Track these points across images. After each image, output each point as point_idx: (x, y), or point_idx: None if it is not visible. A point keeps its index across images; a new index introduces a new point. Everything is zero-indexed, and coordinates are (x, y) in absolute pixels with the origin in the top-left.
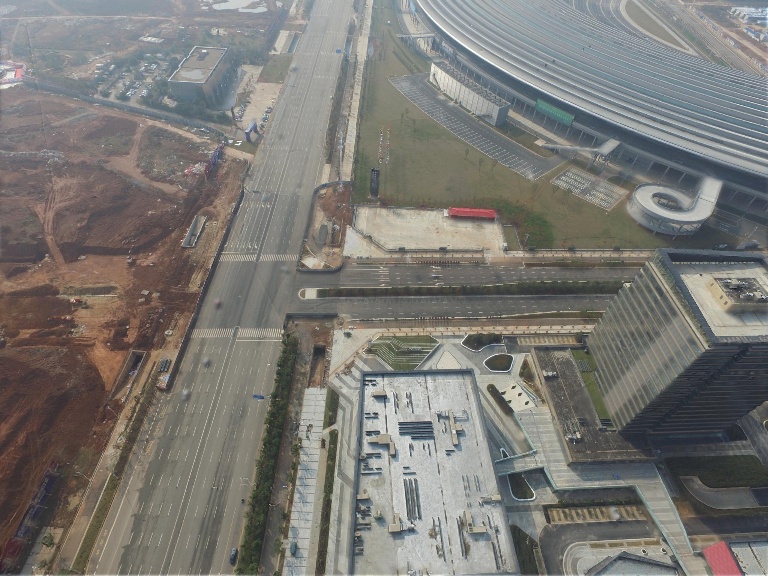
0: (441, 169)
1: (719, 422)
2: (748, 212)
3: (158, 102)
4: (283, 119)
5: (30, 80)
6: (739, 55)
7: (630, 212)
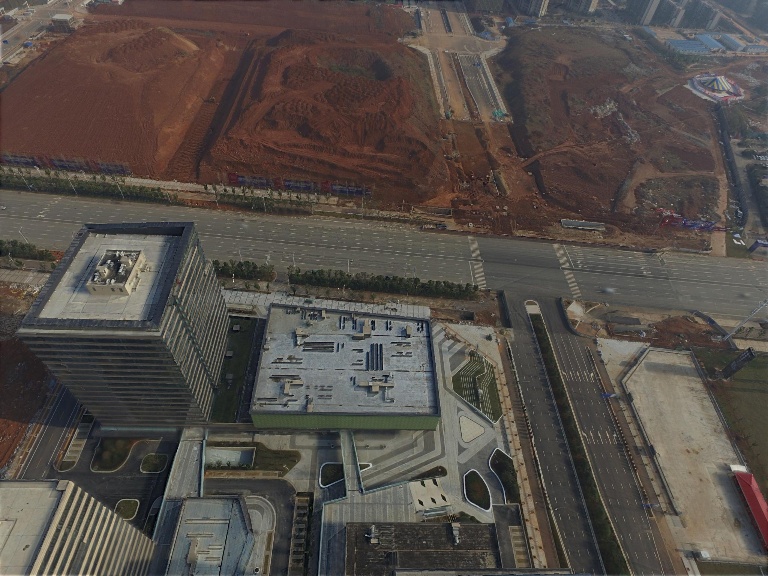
0: None
1: None
2: None
3: (759, 175)
4: None
5: (722, 104)
6: None
7: None
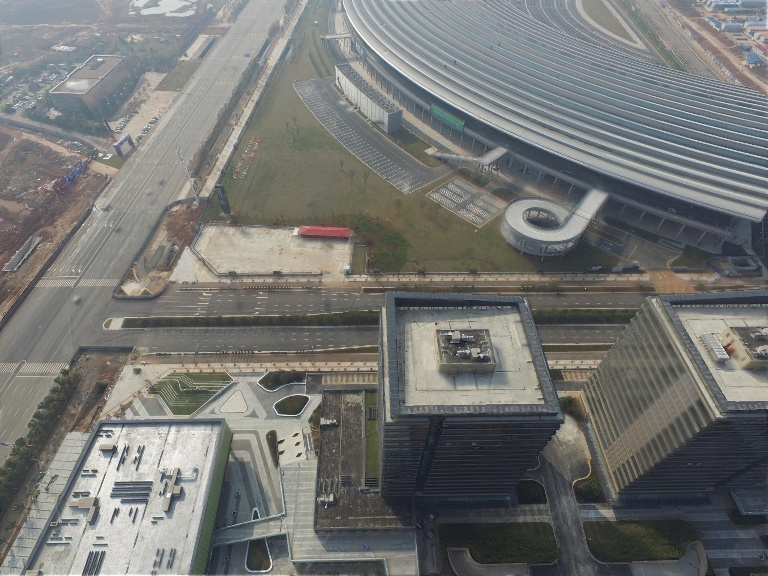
0: (310, 182)
1: (494, 487)
2: (640, 228)
3: (40, 114)
4: (165, 130)
5: None
6: (693, 47)
7: (501, 229)
